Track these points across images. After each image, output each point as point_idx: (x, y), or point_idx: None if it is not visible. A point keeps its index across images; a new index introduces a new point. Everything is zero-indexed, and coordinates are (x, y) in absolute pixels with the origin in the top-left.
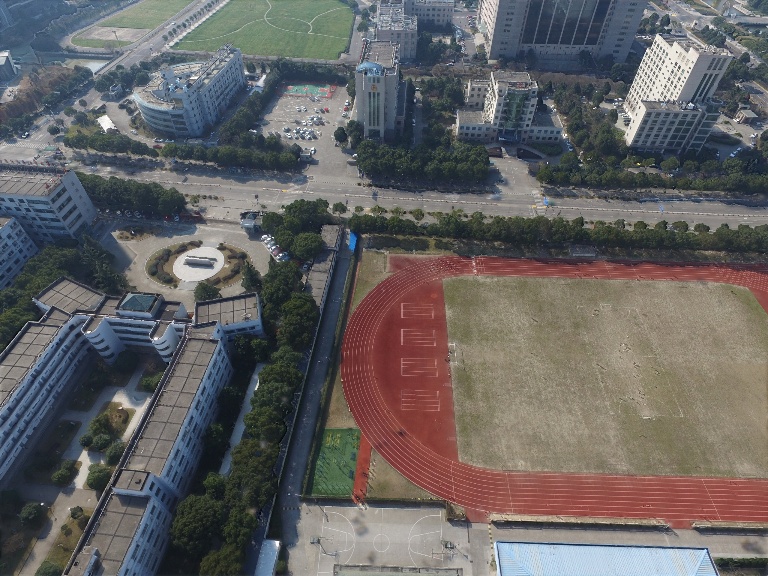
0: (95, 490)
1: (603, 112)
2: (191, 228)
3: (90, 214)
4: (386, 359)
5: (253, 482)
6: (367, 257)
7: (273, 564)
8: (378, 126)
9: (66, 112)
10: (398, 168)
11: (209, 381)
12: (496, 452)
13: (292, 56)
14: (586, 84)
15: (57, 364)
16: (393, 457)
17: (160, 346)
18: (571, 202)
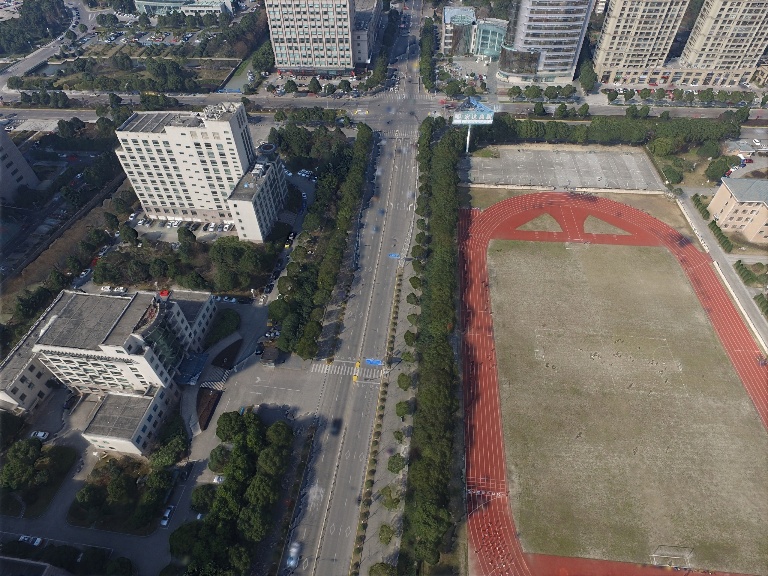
0: None
1: (153, 240)
2: None
3: None
4: None
5: None
6: None
7: None
8: None
9: None
10: None
11: None
12: None
13: None
14: (86, 235)
15: None
16: None
17: None
18: (350, 333)
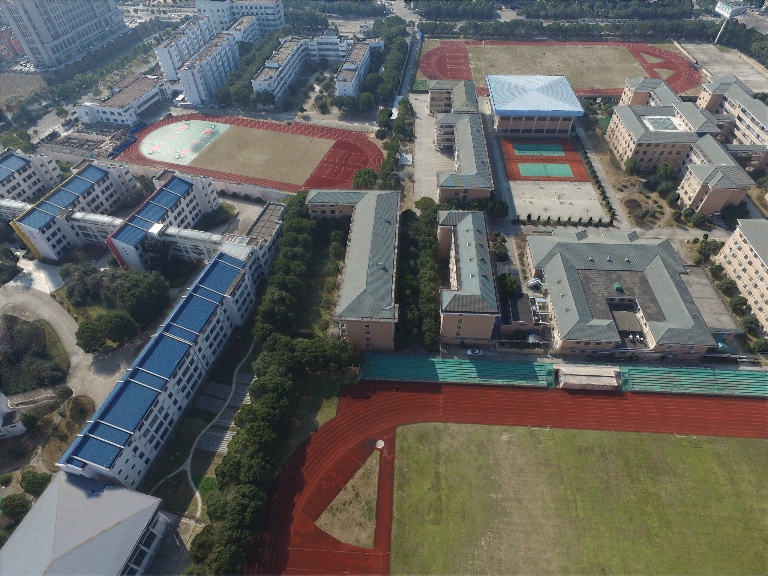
0: (324, 91)
1: None
2: None
3: (284, 25)
4: (440, 66)
5: None
6: (428, 41)
7: None
8: None
9: None
10: (442, 8)
11: None
12: None
13: None
14: None
15: (297, 57)
16: None
17: (343, 48)
18: None
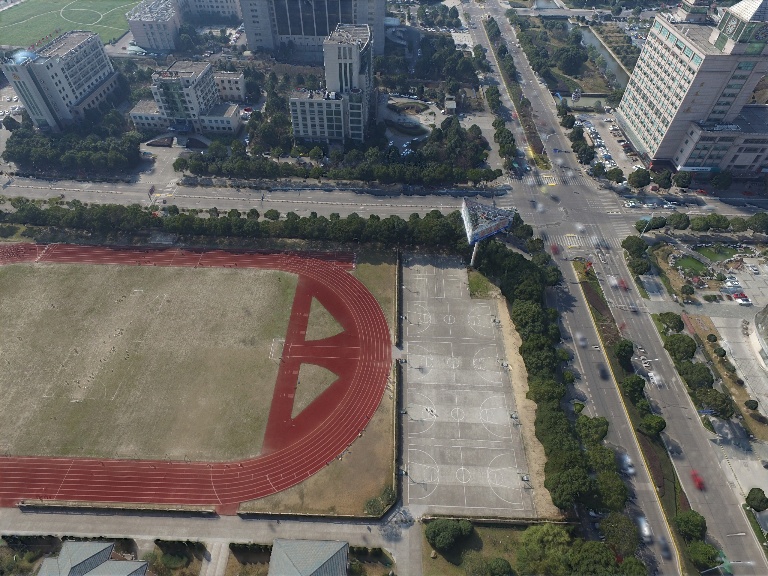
0: None
1: None
2: None
3: None
4: None
5: None
6: None
7: None
8: (42, 115)
9: None
10: (32, 157)
11: None
12: None
13: None
14: None
15: None
16: None
17: None
18: (200, 191)
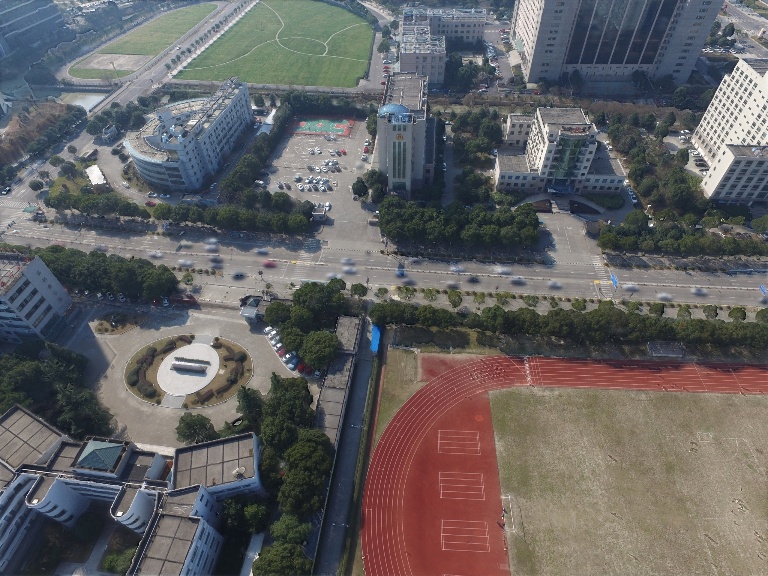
0: None
1: (668, 148)
2: (182, 316)
3: (63, 303)
4: (421, 521)
5: None
6: (393, 358)
7: None
8: (404, 178)
9: (52, 162)
10: (429, 234)
11: None
12: None
13: (305, 84)
14: (645, 114)
15: None
16: None
17: (126, 521)
18: (642, 275)
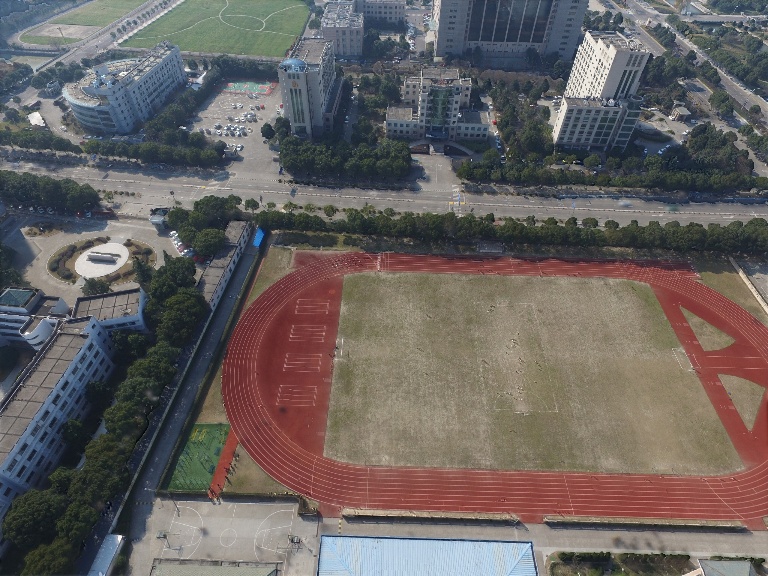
0: None
1: (540, 109)
2: (102, 224)
3: None
4: (271, 355)
5: (98, 476)
6: (273, 253)
7: (111, 558)
8: (304, 123)
9: None
10: (317, 164)
11: (74, 376)
12: (362, 447)
13: (239, 53)
14: (525, 81)
15: None
16: (258, 452)
17: (32, 341)
18: (489, 199)
